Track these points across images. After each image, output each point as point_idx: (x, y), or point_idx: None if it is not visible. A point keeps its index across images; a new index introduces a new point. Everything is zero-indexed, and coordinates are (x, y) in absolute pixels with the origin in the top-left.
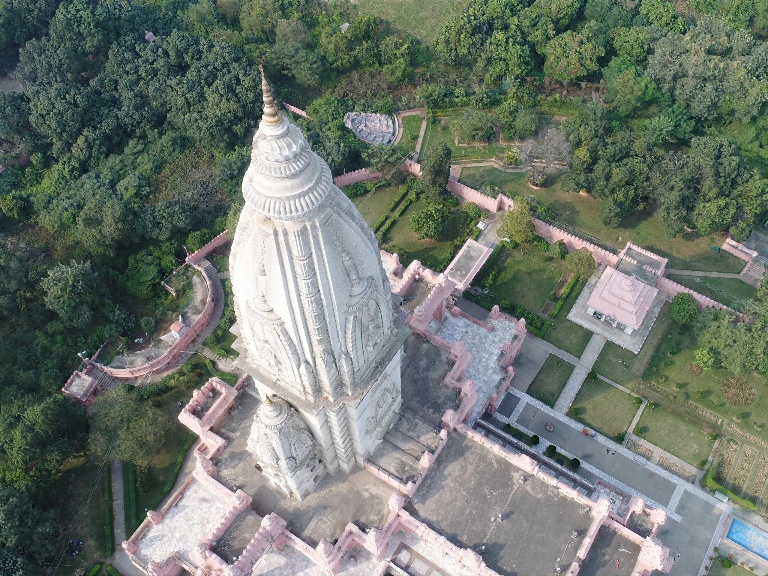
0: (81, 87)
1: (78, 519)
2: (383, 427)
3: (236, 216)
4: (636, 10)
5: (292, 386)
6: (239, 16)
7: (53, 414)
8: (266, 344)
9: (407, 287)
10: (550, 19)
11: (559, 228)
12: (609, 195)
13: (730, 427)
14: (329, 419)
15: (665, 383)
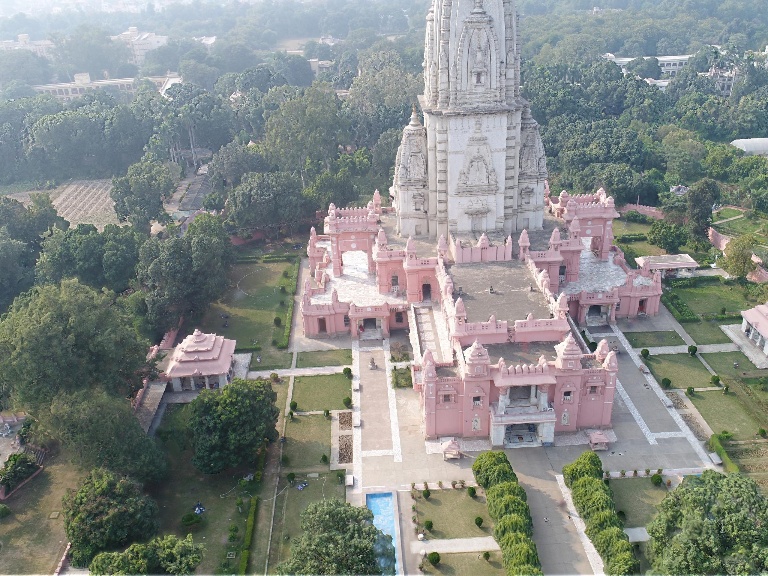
0: None
1: (310, 220)
2: (474, 208)
3: None
4: None
5: None
6: (665, 137)
7: None
8: None
9: None
10: None
11: None
12: None
13: None
14: None
15: (762, 392)
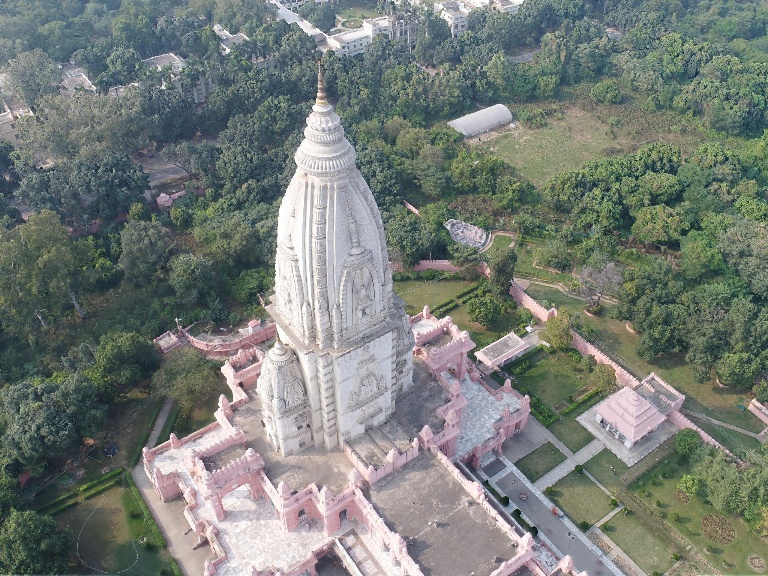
0: (261, 153)
1: (122, 423)
2: (366, 415)
3: None
4: (732, 203)
5: (297, 329)
6: (397, 136)
7: (139, 343)
8: (285, 281)
9: (435, 335)
10: (648, 191)
11: (597, 348)
12: (646, 329)
13: (697, 555)
14: (319, 374)
15: (647, 498)
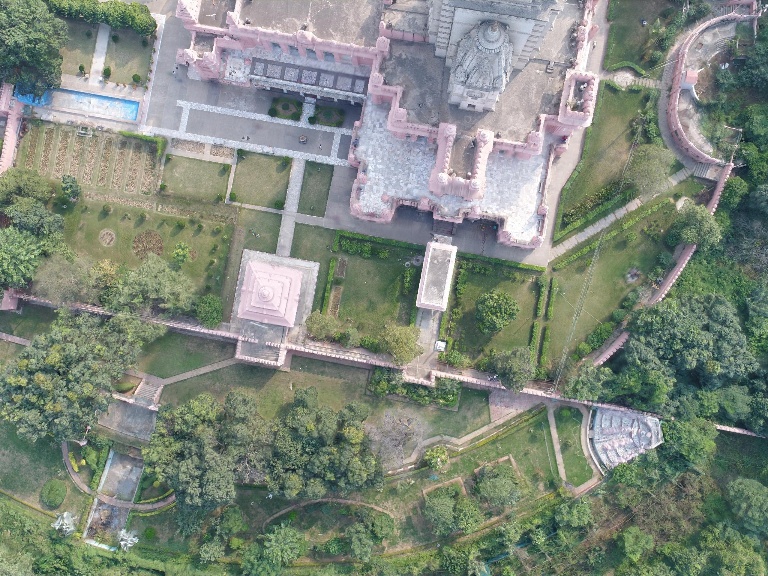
0: None
1: None
2: None
3: (709, 226)
4: None
5: None
6: None
7: None
8: None
9: None
10: None
11: None
12: None
13: (151, 206)
14: None
15: None
